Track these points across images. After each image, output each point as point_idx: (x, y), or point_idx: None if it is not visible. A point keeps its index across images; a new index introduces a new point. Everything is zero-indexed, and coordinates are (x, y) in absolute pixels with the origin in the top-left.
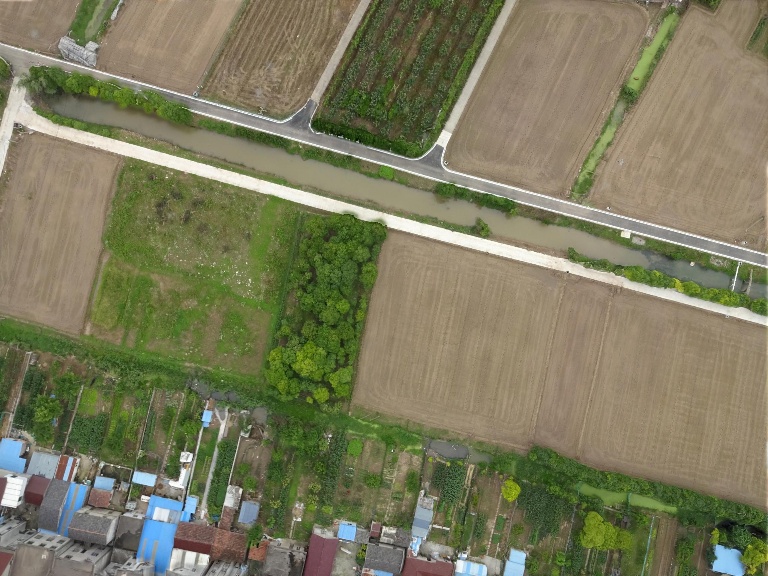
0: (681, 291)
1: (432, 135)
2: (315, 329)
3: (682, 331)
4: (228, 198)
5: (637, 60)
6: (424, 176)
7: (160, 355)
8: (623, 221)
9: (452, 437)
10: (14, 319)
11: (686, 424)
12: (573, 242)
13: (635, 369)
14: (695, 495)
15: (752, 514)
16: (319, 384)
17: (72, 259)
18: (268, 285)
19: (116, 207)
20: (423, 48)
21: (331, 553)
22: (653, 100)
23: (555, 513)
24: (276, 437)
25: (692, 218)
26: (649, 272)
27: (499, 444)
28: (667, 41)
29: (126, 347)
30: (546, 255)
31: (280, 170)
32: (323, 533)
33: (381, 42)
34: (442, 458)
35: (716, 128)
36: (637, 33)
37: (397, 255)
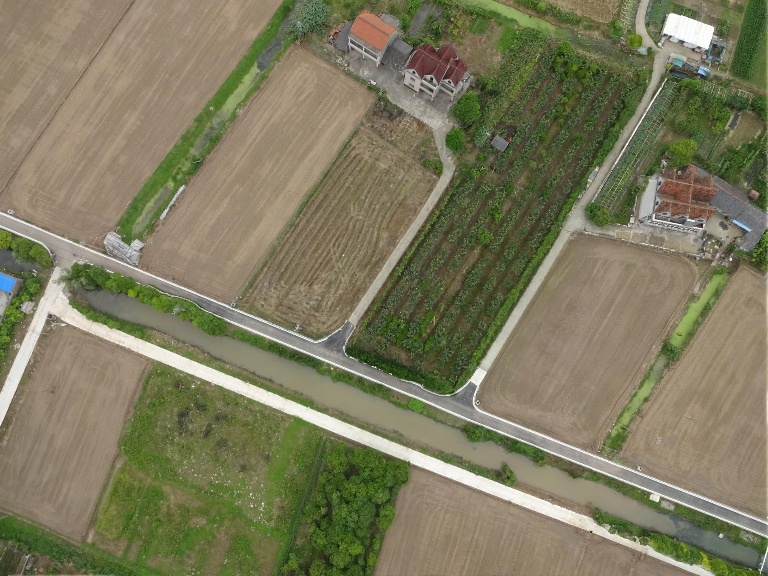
0: (707, 569)
1: (467, 372)
2: (324, 572)
3: None
4: (252, 416)
5: (682, 315)
6: (454, 413)
7: (160, 573)
8: (653, 483)
9: None
10: (17, 517)
11: None
12: (599, 498)
13: None
14: None
15: None
16: None
17: (85, 460)
18: (281, 511)
19: (138, 412)
20: (467, 283)
21: None
22: (695, 359)
23: None
24: None
25: (725, 487)
26: (676, 546)
27: None
28: (714, 299)
29: (127, 561)
30: (570, 511)
31: (308, 389)
32: None
33: (426, 272)
34: None
35: (757, 395)
36: (684, 288)
37: (417, 493)
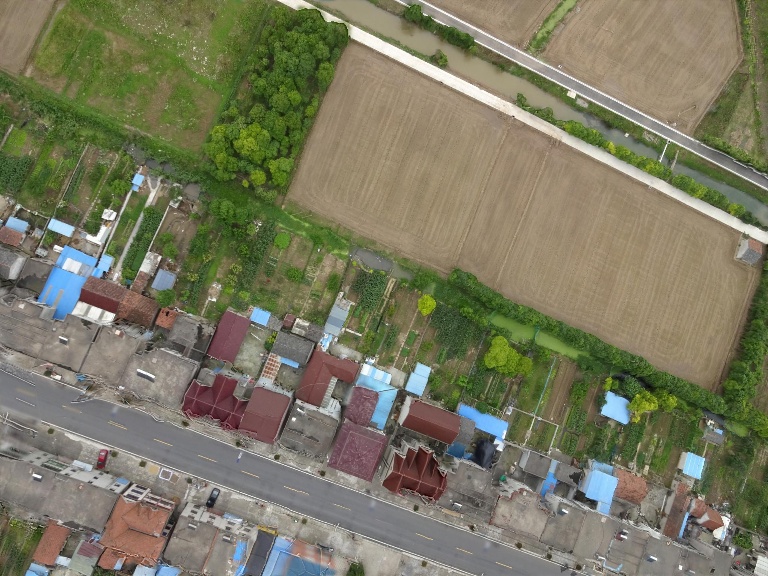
0: (613, 152)
1: None
2: (263, 111)
3: (608, 193)
4: None
5: None
6: None
7: (100, 112)
8: (571, 82)
9: (379, 249)
10: None
11: (598, 278)
12: (523, 92)
13: (560, 219)
14: (596, 338)
15: (644, 365)
16: (258, 167)
17: None
18: (223, 67)
19: None
20: None
21: (241, 333)
22: None
23: (465, 337)
24: (205, 213)
25: (633, 93)
26: (587, 128)
27: (423, 264)
28: None
29: (66, 97)
30: (496, 97)
31: None
32: (236, 313)
33: None
34: (366, 267)
35: (667, 18)
36: None
37: (355, 66)
